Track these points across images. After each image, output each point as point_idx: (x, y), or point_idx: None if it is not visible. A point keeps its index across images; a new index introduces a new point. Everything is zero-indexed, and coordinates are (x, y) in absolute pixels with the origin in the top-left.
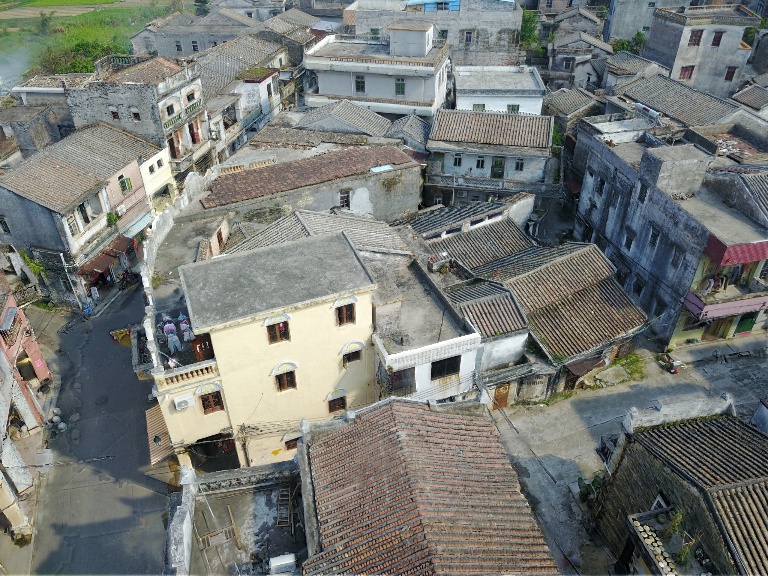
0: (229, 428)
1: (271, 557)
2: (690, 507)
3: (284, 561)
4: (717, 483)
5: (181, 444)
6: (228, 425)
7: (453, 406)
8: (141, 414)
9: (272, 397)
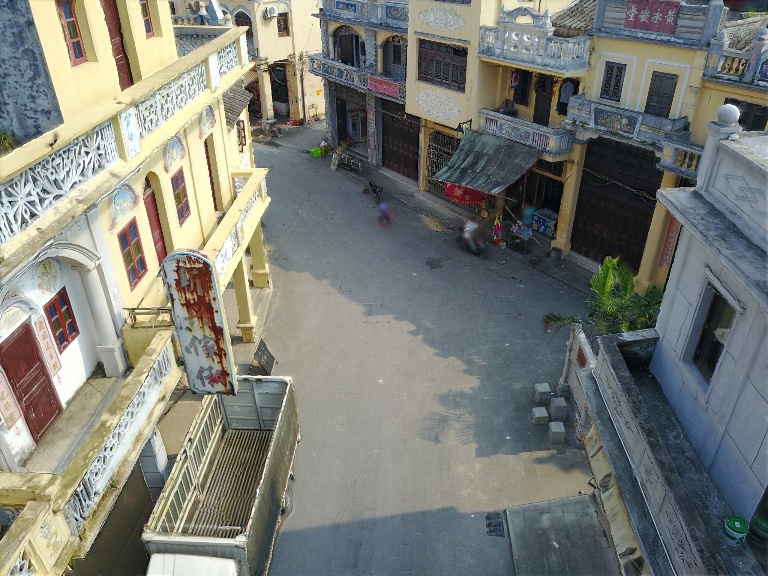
0: (293, 54)
1: None
2: None
3: None
4: None
5: (265, 61)
6: (292, 52)
7: None
8: None
9: (317, 31)
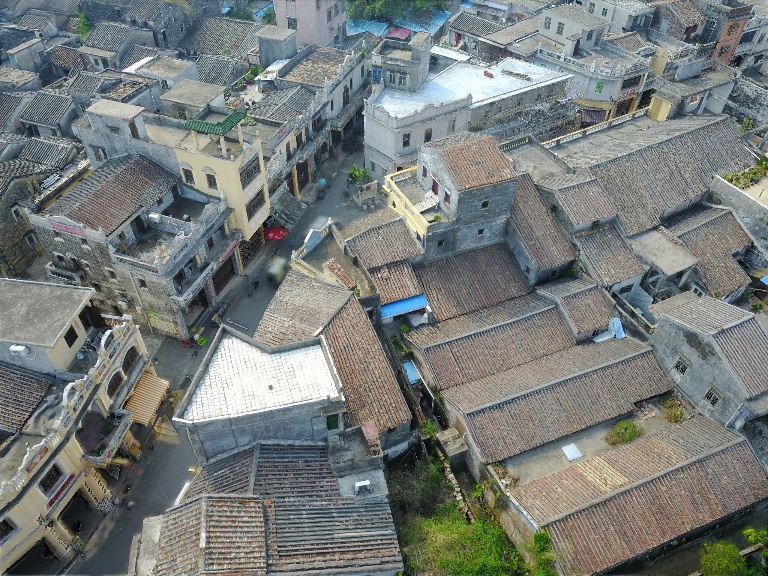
0: None
1: (155, 242)
2: (17, 190)
3: (153, 215)
4: (3, 180)
5: None
6: None
7: (42, 216)
8: (148, 491)
9: None
